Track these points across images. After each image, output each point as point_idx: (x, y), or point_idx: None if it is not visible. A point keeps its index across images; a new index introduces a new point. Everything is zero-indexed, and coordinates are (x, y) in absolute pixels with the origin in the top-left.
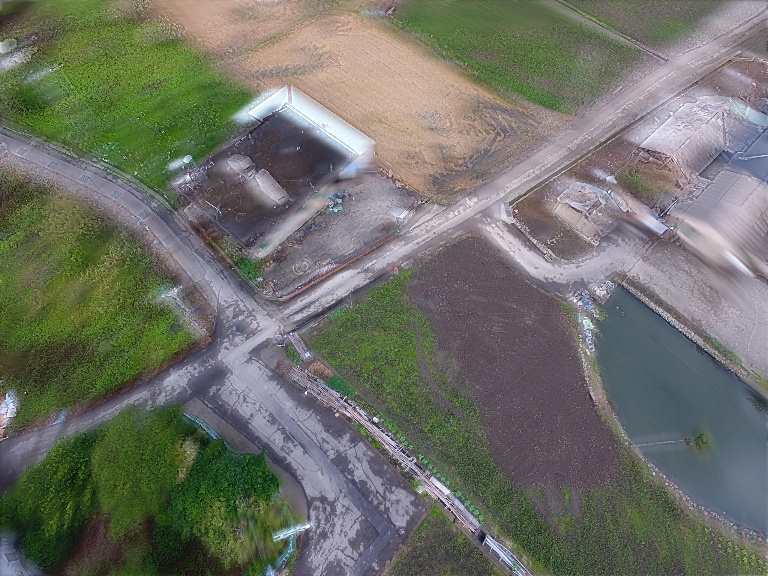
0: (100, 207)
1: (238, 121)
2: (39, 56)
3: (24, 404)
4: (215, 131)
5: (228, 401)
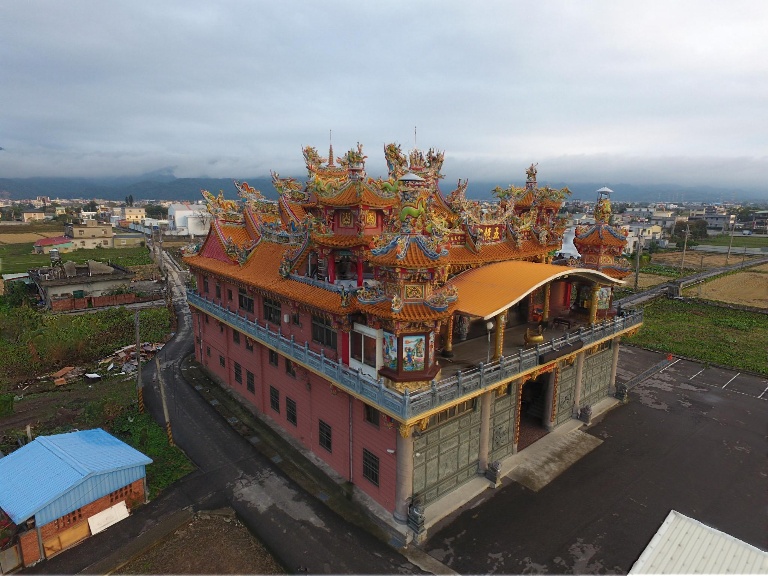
0: None
1: (7, 281)
2: None
3: None
4: None
5: None
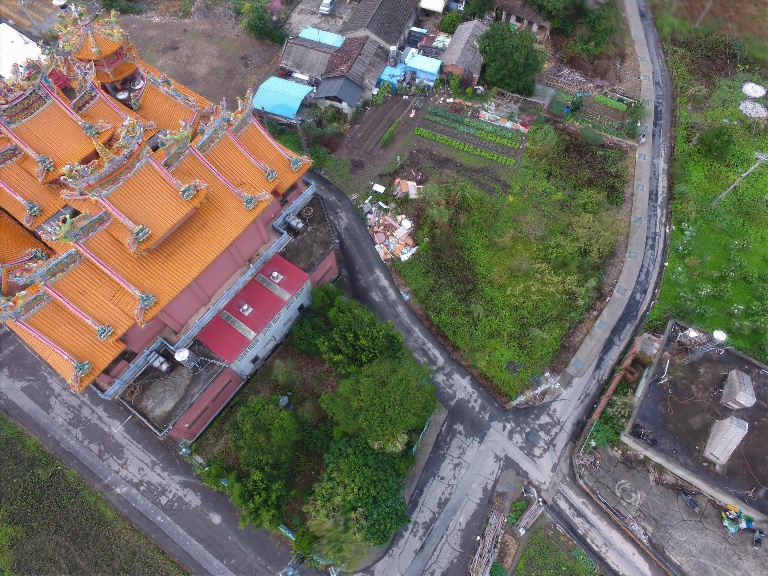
0: (613, 247)
1: None
2: (760, 123)
3: (413, 263)
4: (765, 331)
5: (451, 447)
